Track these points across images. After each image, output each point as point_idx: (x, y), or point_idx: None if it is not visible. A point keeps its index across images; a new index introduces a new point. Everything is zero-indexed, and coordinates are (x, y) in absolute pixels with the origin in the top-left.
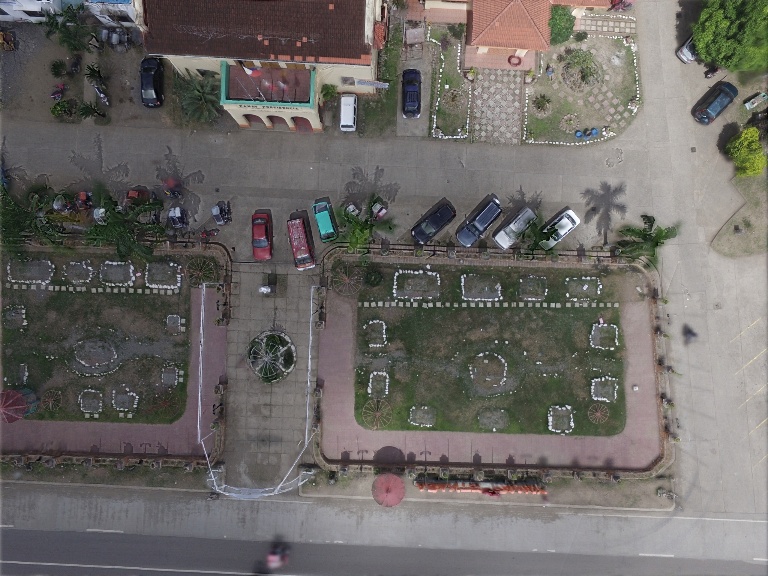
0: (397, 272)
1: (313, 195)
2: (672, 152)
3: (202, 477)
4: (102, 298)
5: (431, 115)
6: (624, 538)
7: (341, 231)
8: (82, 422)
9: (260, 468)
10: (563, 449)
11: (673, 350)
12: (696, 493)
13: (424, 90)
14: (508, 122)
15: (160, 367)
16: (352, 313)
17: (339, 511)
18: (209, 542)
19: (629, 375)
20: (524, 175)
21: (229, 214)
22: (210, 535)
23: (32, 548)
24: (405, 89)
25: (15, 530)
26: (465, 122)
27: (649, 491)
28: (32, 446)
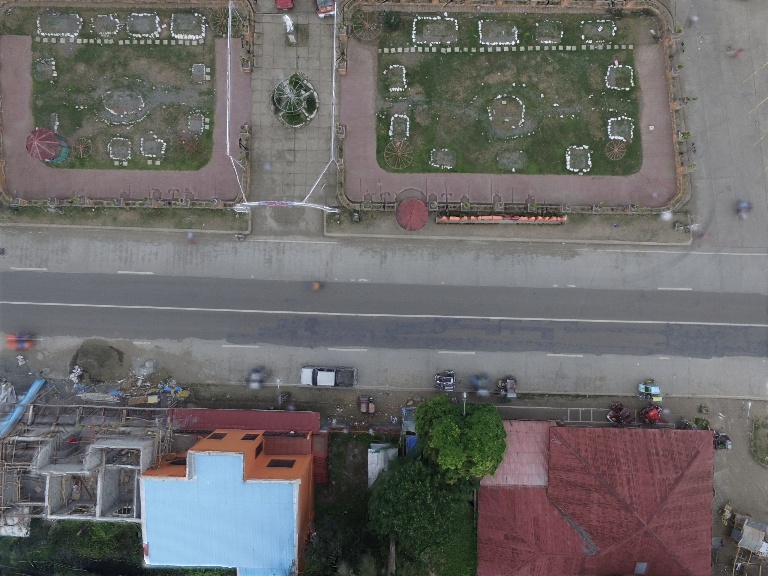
0: (416, 18)
1: None
2: None
3: (229, 218)
4: (129, 50)
5: None
6: (643, 273)
7: None
8: (111, 170)
9: (285, 211)
10: (581, 189)
11: (687, 91)
12: (713, 229)
13: None
14: None
15: (186, 115)
16: (372, 60)
17: (363, 251)
18: (237, 282)
19: (645, 116)
20: None
21: None
22: (238, 275)
23: (65, 290)
24: None
25: (48, 273)
26: None
27: (667, 225)
28: (63, 193)
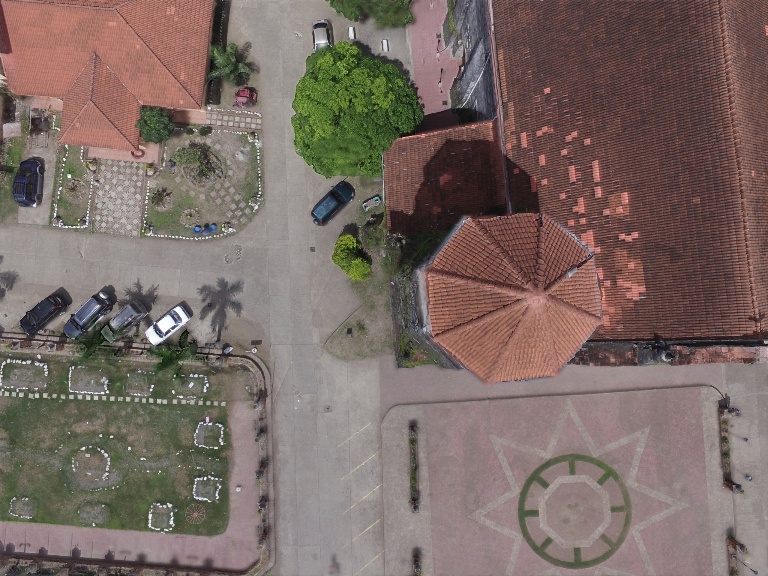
0: (5, 361)
1: None
2: (291, 251)
3: None
4: None
5: (53, 204)
6: None
7: None
8: None
9: None
10: (163, 547)
11: (280, 452)
12: None
13: (47, 178)
14: (129, 214)
15: None
16: None
17: None
18: None
19: (235, 475)
20: (142, 268)
21: None
22: None
23: None
24: (14, 180)
25: None
26: (85, 212)
27: None
28: None
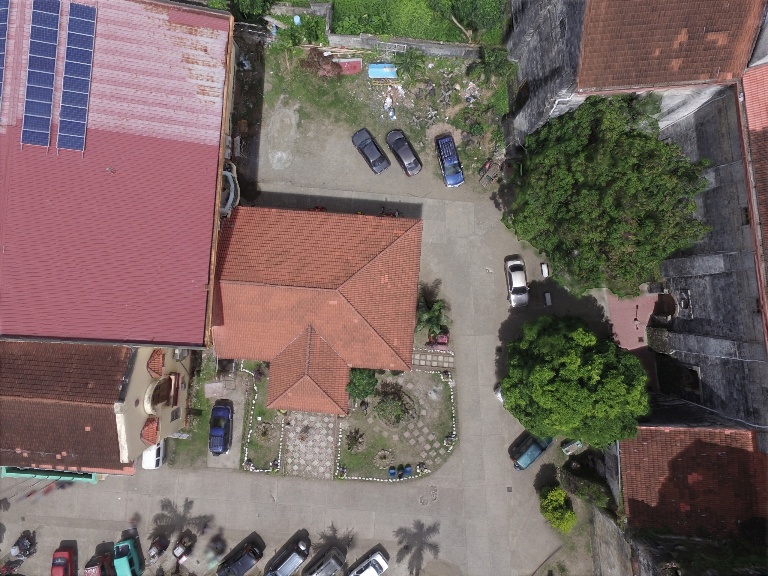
0: None
1: (120, 526)
2: (487, 491)
3: None
4: None
5: (243, 447)
6: None
7: (148, 564)
8: None
9: None
10: None
11: None
12: None
13: (236, 421)
14: (321, 456)
15: None
16: None
17: None
18: None
19: None
20: (336, 511)
21: (32, 547)
22: None
23: None
24: None
25: None
26: (277, 455)
27: None
28: None
